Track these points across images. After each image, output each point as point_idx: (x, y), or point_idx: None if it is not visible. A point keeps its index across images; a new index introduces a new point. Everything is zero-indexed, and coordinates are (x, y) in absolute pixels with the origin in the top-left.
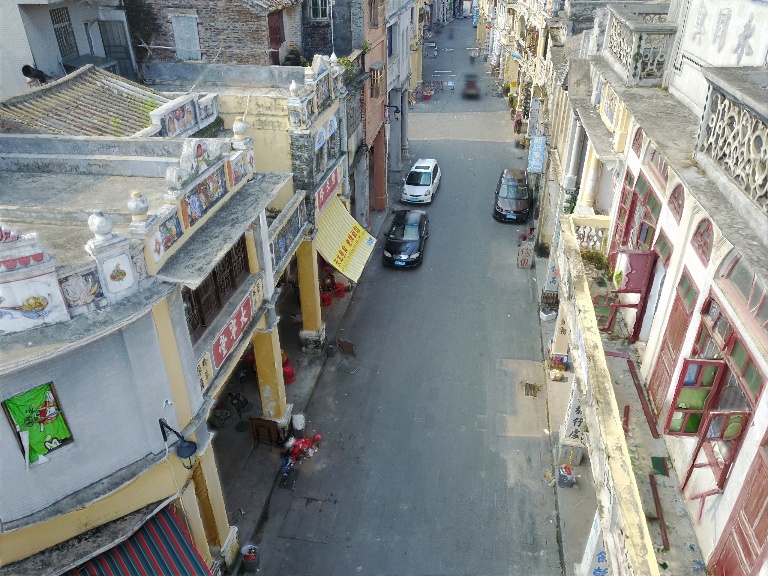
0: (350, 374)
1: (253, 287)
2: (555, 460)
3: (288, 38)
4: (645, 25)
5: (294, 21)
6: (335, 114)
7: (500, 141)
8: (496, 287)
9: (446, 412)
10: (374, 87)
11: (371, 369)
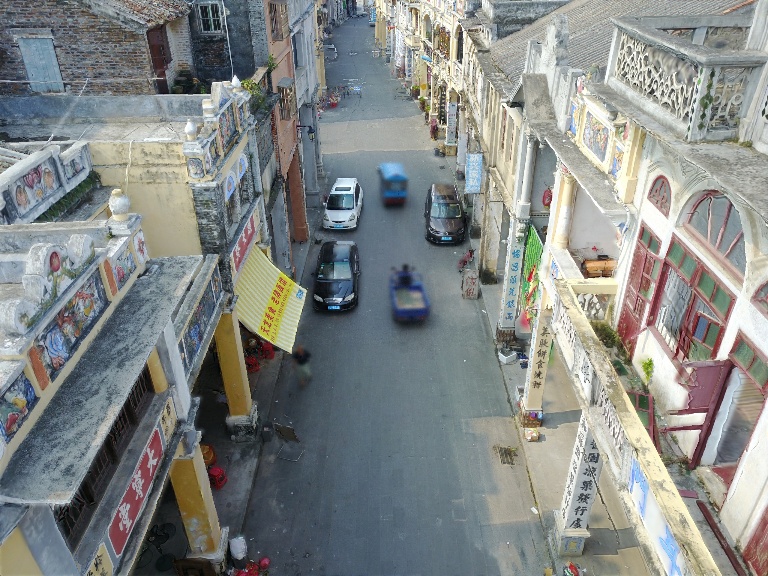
0: (294, 463)
1: (161, 413)
2: (553, 552)
3: (175, 57)
4: (722, 56)
5: (181, 36)
6: (244, 150)
7: (418, 149)
8: (444, 326)
9: (416, 502)
10: (284, 108)
11: (318, 452)
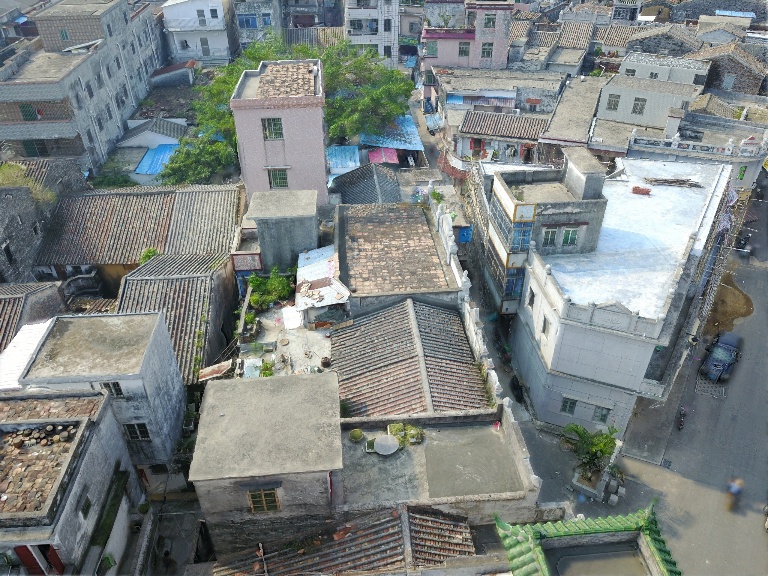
0: (759, 206)
1: None
2: None
3: None
4: None
5: None
6: None
7: None
8: None
9: None
10: None
11: (767, 206)
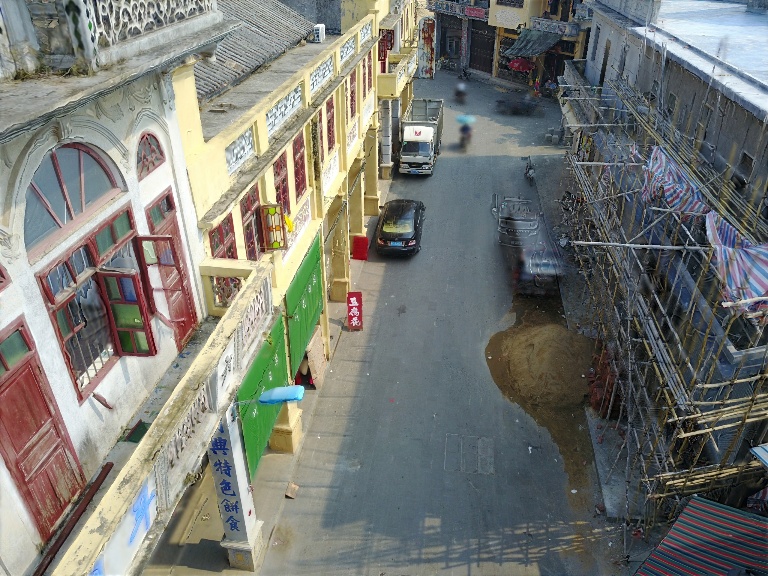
0: None
1: None
2: None
3: None
4: None
5: None
6: None
7: None
8: None
9: None
10: None
11: None
